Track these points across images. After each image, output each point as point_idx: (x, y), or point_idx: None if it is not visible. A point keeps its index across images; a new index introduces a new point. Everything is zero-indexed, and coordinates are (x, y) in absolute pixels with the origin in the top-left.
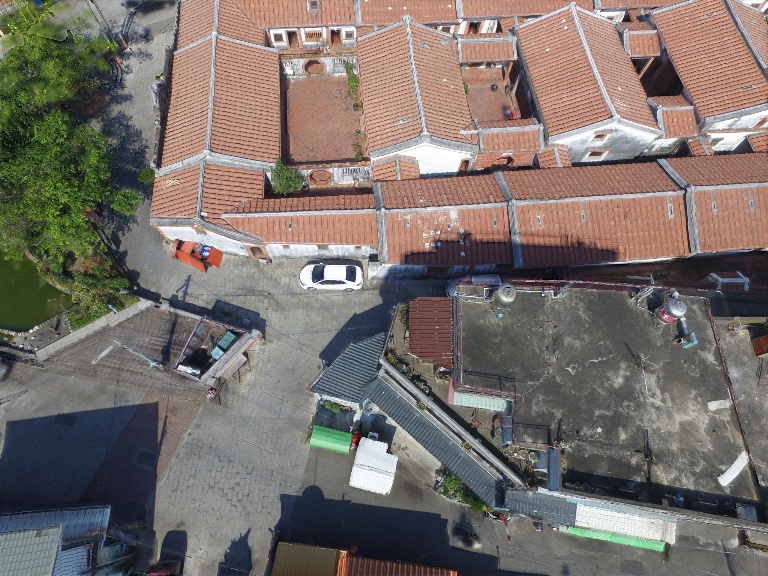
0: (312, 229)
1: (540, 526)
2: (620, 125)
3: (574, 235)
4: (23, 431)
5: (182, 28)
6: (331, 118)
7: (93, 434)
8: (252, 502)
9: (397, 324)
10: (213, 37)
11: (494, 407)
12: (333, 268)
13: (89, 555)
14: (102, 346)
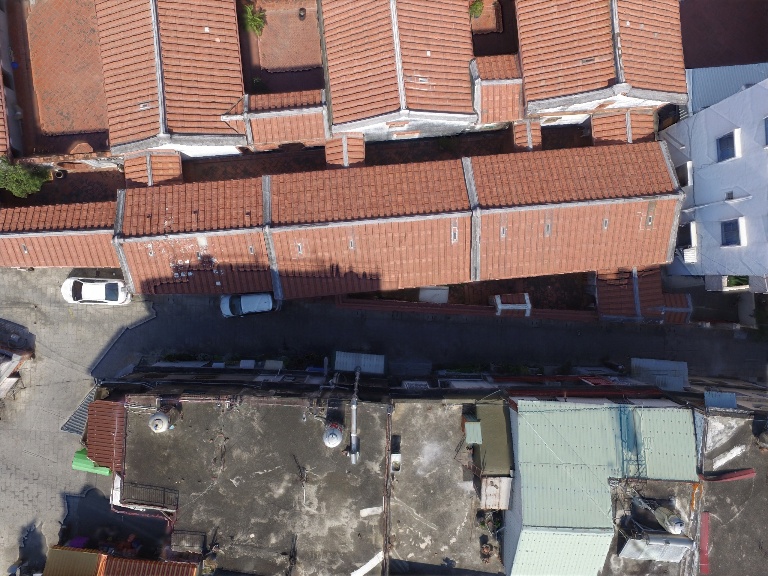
0: (51, 252)
1: None
2: (413, 118)
3: (340, 264)
4: None
5: None
6: (88, 66)
7: None
8: (41, 502)
9: None
10: None
11: None
12: (90, 287)
13: None
14: None
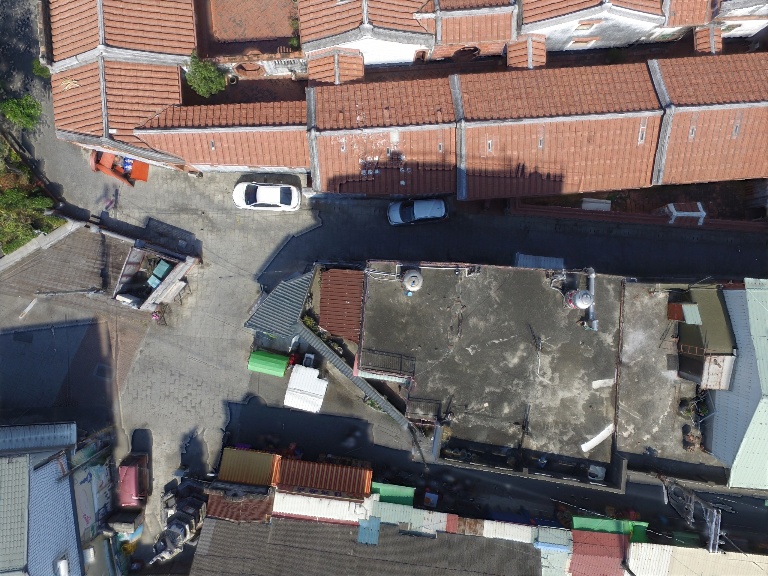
0: (238, 148)
1: None
2: (610, 14)
3: (526, 164)
4: None
5: None
6: None
7: (52, 350)
8: (204, 408)
9: (316, 282)
10: None
11: (395, 379)
12: (266, 190)
13: (62, 466)
14: (40, 268)
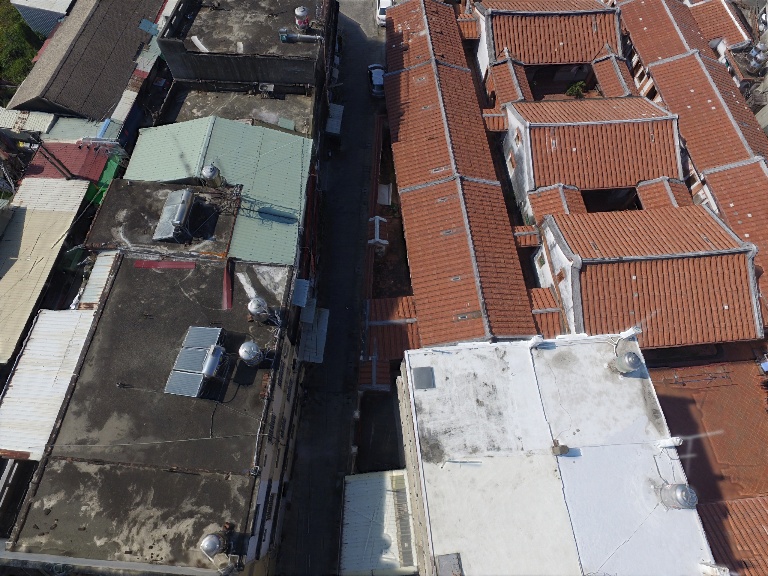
0: None
1: None
2: None
3: (410, 104)
4: None
5: None
6: None
7: None
8: None
9: None
10: None
11: None
12: (389, 2)
13: None
14: None
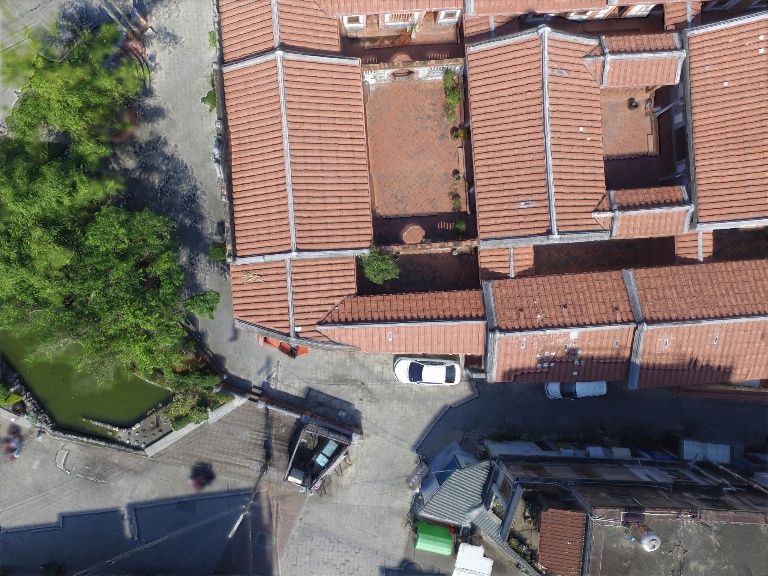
0: (414, 339)
1: None
2: None
3: (700, 358)
4: (151, 516)
5: (225, 17)
6: (423, 151)
7: (214, 519)
8: (362, 575)
9: None
10: (278, 60)
11: None
12: (432, 370)
13: None
14: (205, 440)
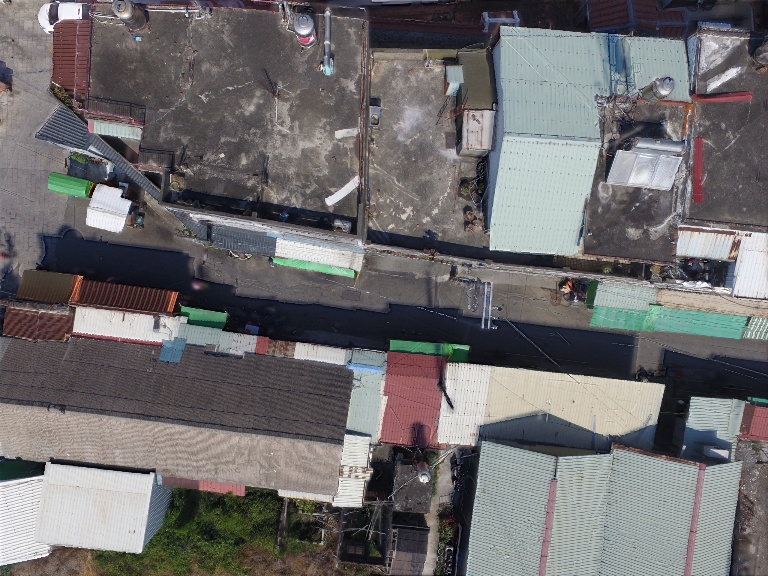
0: None
1: (271, 262)
2: None
3: None
4: None
5: None
6: None
7: None
8: (18, 242)
9: None
10: None
11: (133, 136)
12: (67, 6)
13: None
14: None
